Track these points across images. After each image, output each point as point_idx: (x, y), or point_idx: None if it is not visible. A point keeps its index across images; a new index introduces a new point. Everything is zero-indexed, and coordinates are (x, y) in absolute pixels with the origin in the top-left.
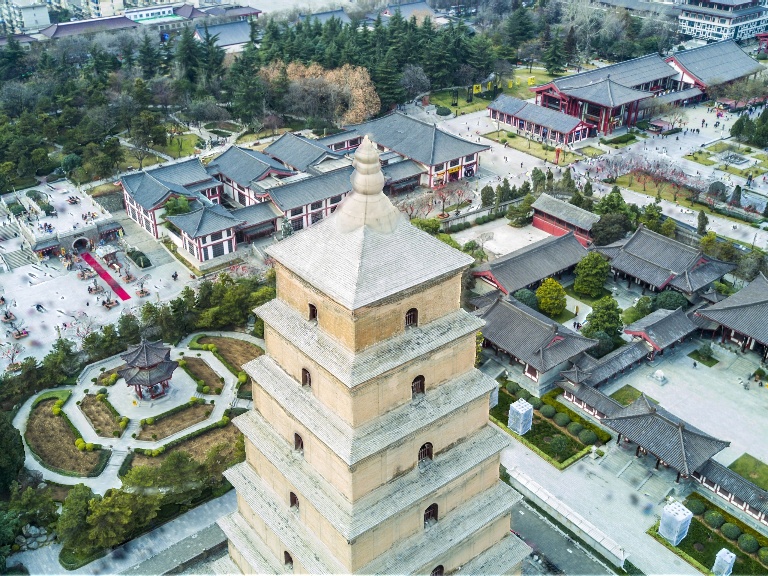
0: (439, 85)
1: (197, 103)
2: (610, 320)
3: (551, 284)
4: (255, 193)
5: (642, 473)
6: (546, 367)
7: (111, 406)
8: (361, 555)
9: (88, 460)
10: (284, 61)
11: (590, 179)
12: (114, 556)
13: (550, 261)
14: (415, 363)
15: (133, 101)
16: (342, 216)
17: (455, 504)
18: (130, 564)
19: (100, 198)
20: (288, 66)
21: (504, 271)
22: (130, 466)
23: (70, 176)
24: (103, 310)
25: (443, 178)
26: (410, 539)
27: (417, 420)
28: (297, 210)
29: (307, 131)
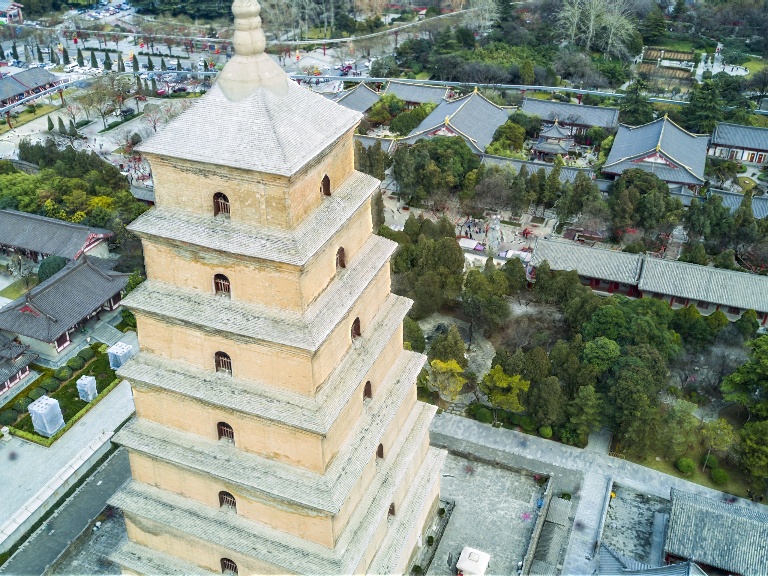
0: None
1: None
2: None
3: None
4: None
5: None
6: None
7: None
8: None
9: None
10: None
11: None
12: None
13: None
14: None
15: None
16: None
17: None
18: None
19: None
20: None
21: None
22: None
23: None
24: None
25: None
26: None
27: None
28: None
29: None
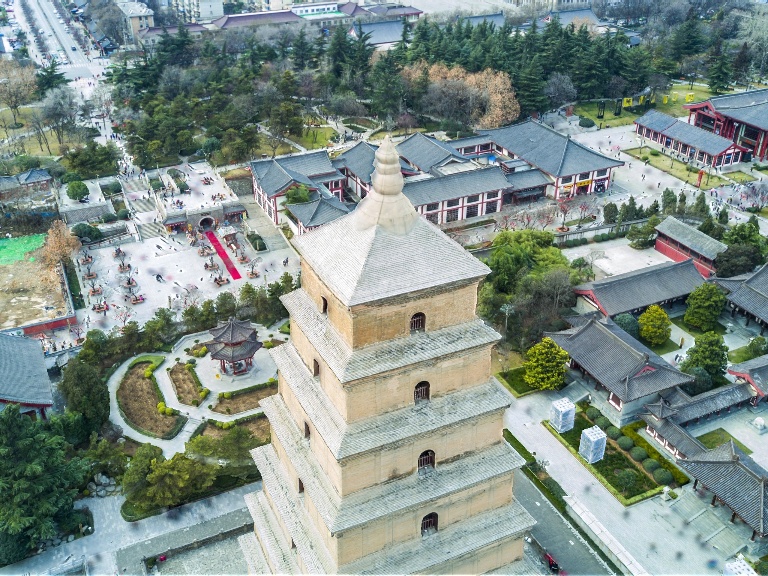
0: (586, 96)
1: (338, 98)
2: (712, 357)
3: (655, 311)
4: None
5: (715, 524)
6: (630, 397)
7: (196, 376)
8: (349, 550)
9: (166, 423)
10: (429, 62)
11: (727, 206)
12: (169, 515)
13: (661, 287)
14: (418, 368)
15: (277, 92)
16: (359, 214)
17: (459, 517)
18: (181, 525)
19: (232, 181)
20: (431, 67)
21: (607, 292)
22: (201, 434)
23: (209, 158)
24: (214, 286)
25: (570, 191)
26: (405, 544)
27: (416, 425)
28: None
29: (441, 133)
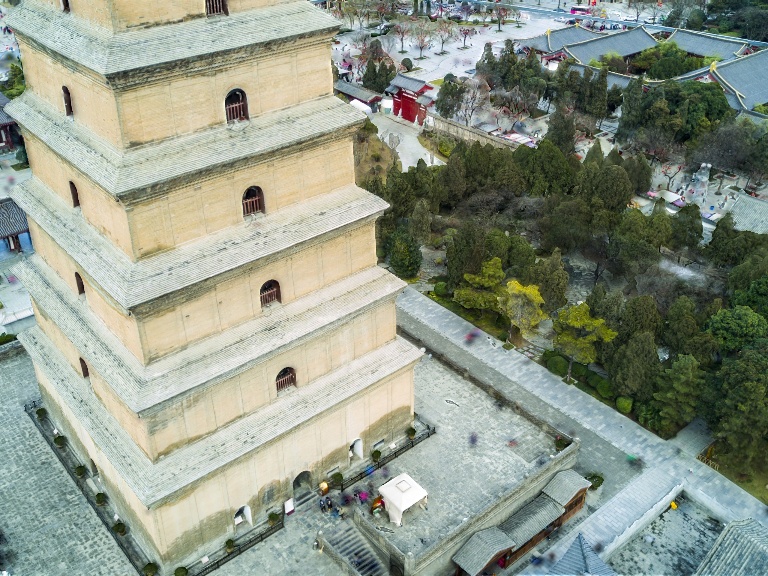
0: None
1: None
2: None
3: None
4: None
5: None
6: None
7: None
8: None
9: None
10: None
11: None
12: None
13: None
14: None
15: None
16: None
17: None
18: None
19: None
20: None
21: None
22: None
23: None
24: None
25: None
26: None
27: None
28: None
29: None
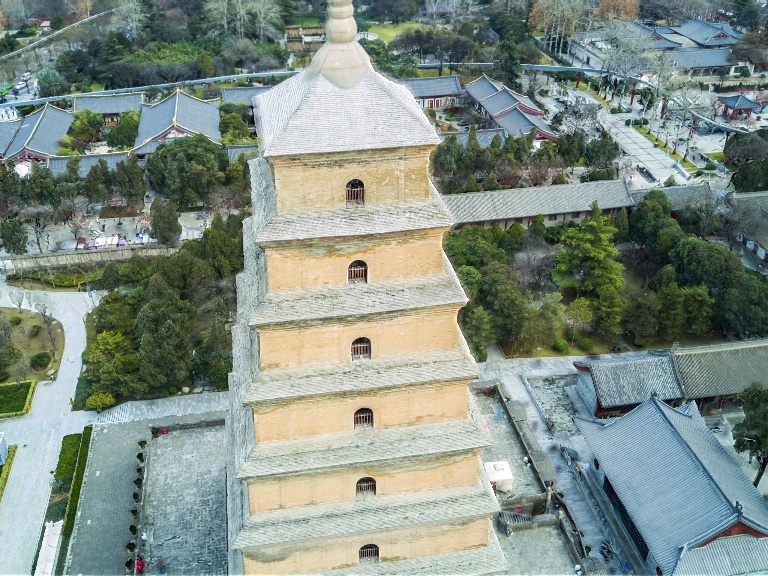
0: None
1: None
2: None
3: None
4: None
5: None
6: None
7: None
8: None
9: None
10: None
11: None
12: None
13: None
14: None
15: None
16: None
17: None
18: None
19: None
20: None
21: None
22: None
23: None
24: None
25: None
26: None
27: None
28: None
29: None
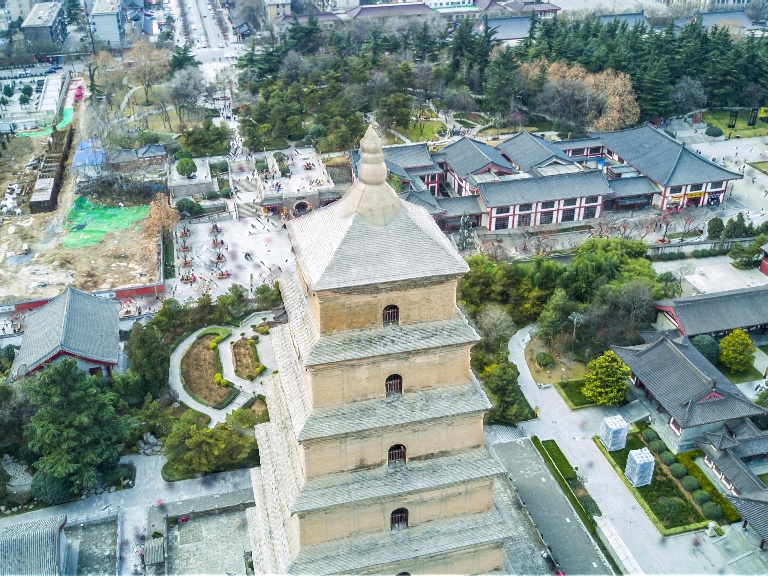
0: (718, 103)
1: (451, 92)
2: None
3: (738, 336)
4: (469, 185)
5: (759, 568)
6: (689, 422)
7: (256, 352)
8: (312, 532)
9: (219, 393)
10: (549, 60)
11: None
12: (204, 481)
13: (752, 311)
14: (389, 360)
15: (389, 83)
16: (342, 201)
17: (432, 516)
18: (213, 491)
19: (333, 168)
20: (551, 65)
21: (689, 311)
22: (249, 408)
23: (315, 144)
24: None
25: (679, 202)
26: (372, 535)
27: (384, 417)
28: (503, 209)
29: (552, 133)
